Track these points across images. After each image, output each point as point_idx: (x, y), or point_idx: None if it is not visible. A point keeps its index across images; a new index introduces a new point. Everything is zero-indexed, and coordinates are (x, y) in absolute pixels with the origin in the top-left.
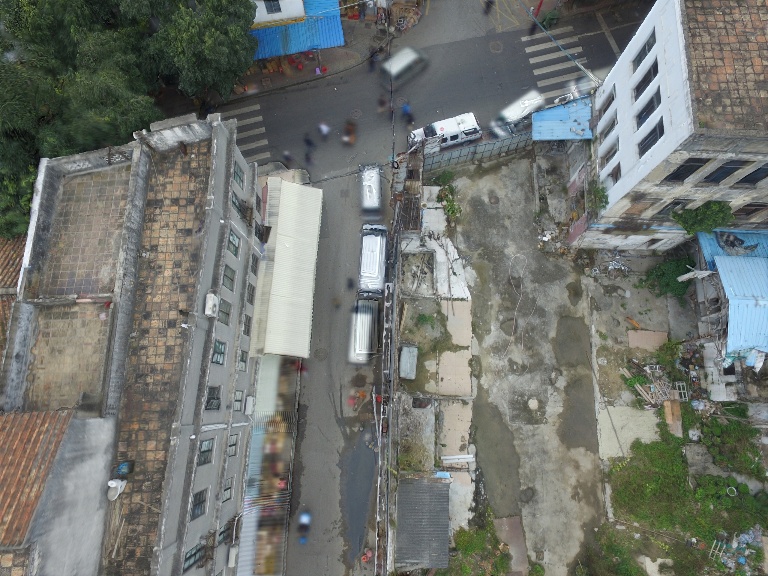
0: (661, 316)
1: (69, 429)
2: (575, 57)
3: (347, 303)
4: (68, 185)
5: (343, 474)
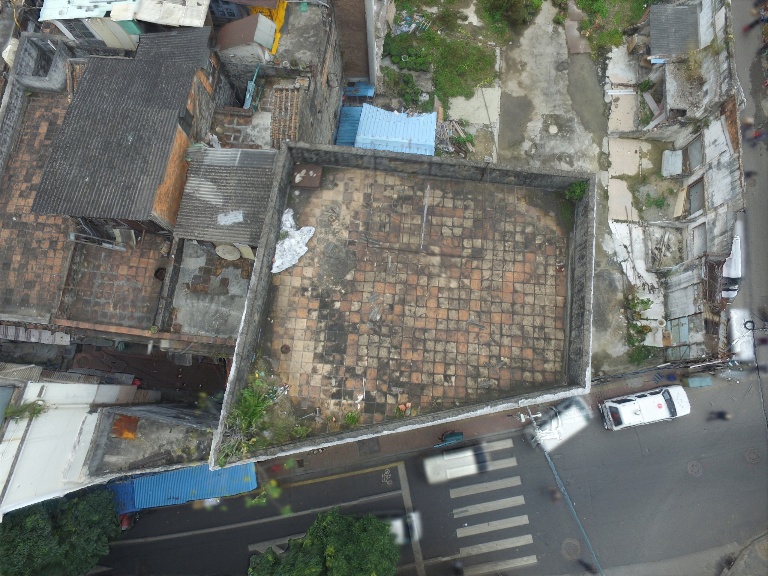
0: None
1: None
2: (468, 520)
3: None
4: None
5: None
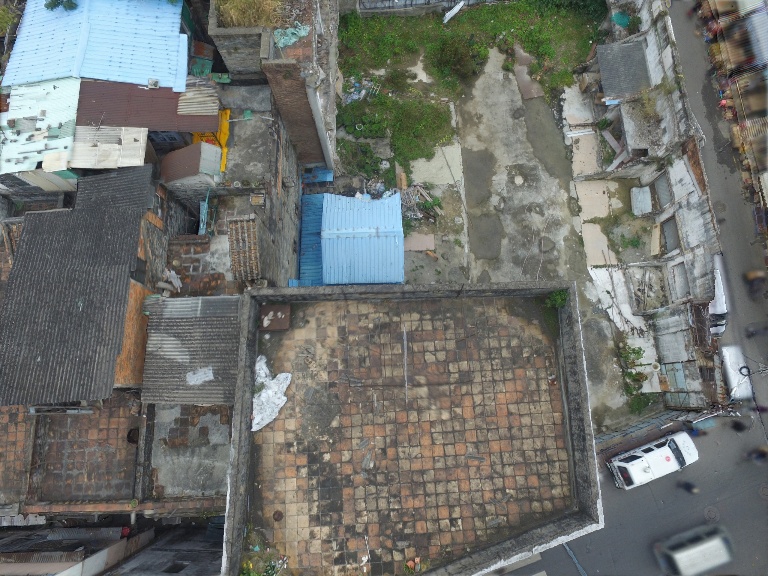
0: None
1: None
2: None
3: None
4: None
5: None
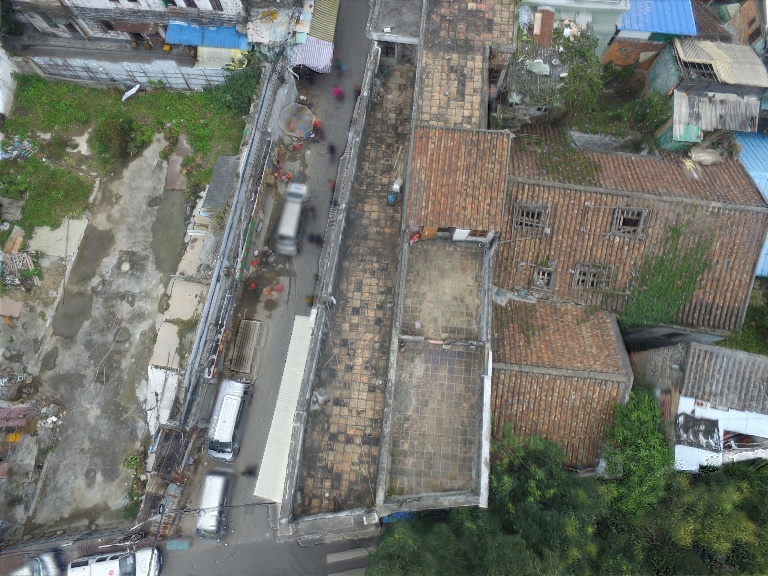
0: None
1: (404, 209)
2: None
3: (269, 380)
4: (467, 478)
5: (297, 234)
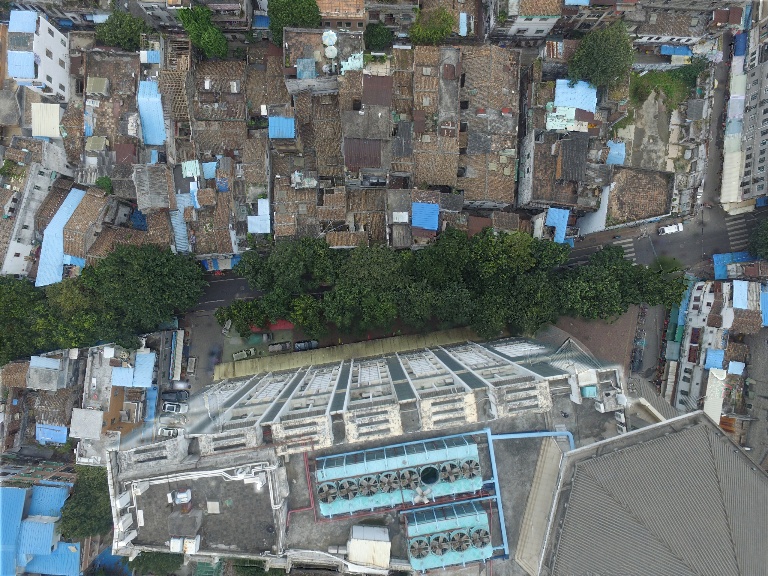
0: None
1: None
2: None
3: None
4: None
5: None
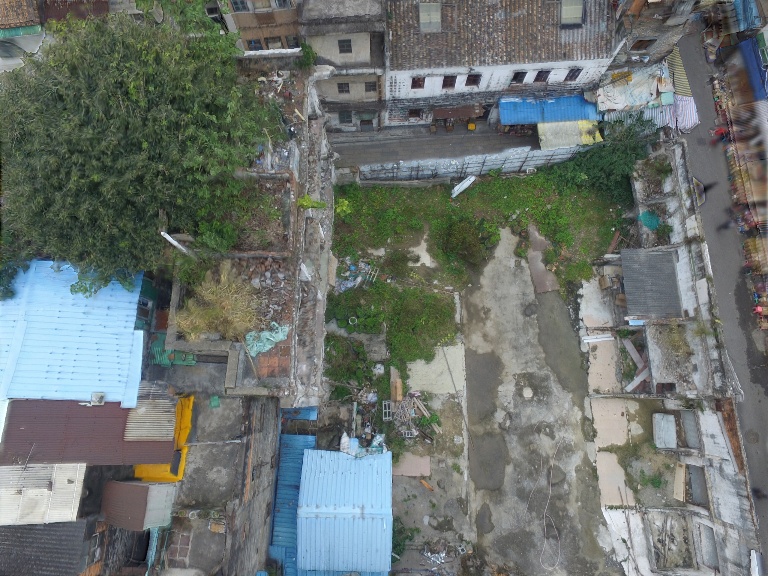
0: (393, 494)
1: None
2: None
3: None
4: None
5: None
